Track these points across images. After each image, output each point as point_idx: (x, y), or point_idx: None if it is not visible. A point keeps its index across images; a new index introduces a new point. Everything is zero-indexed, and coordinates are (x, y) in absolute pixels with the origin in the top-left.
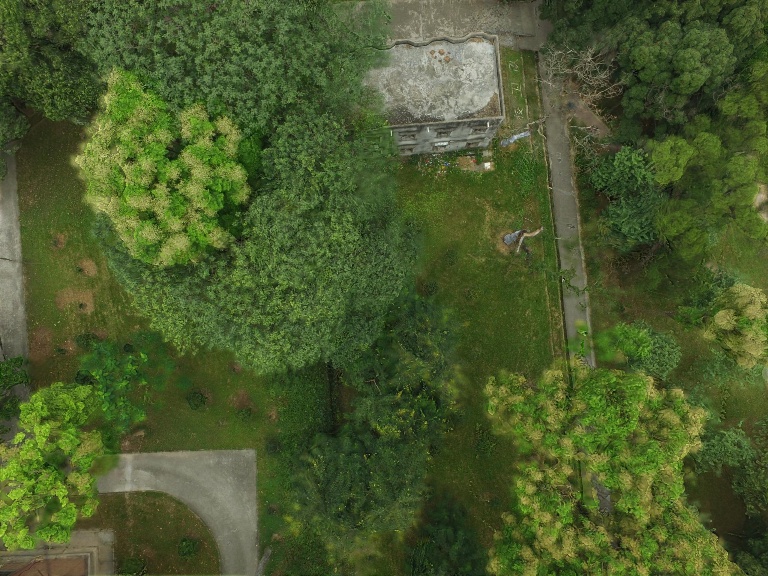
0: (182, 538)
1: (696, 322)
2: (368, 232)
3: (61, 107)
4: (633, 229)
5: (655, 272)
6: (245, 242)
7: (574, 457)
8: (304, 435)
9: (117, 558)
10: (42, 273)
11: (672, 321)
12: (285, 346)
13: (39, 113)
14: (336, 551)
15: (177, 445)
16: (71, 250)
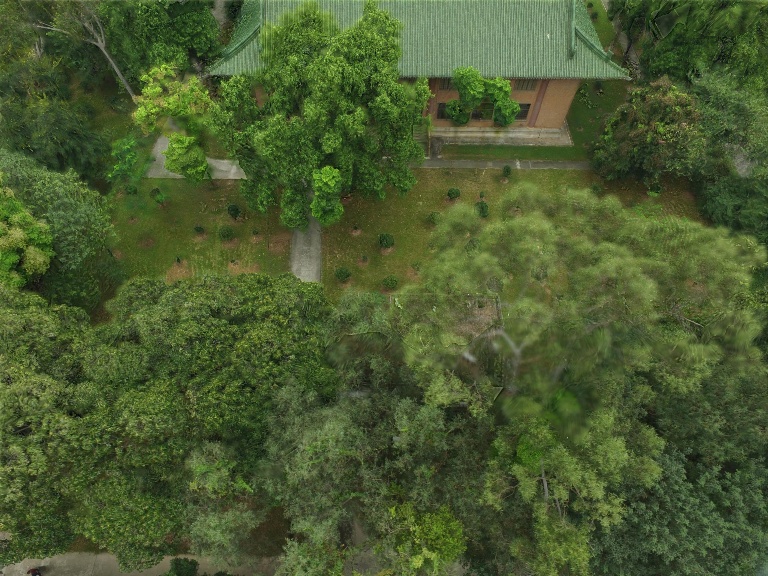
0: None
1: None
2: None
3: None
4: None
5: None
6: None
7: None
8: None
9: None
10: None
11: None
12: None
13: None
14: None
15: None
16: None
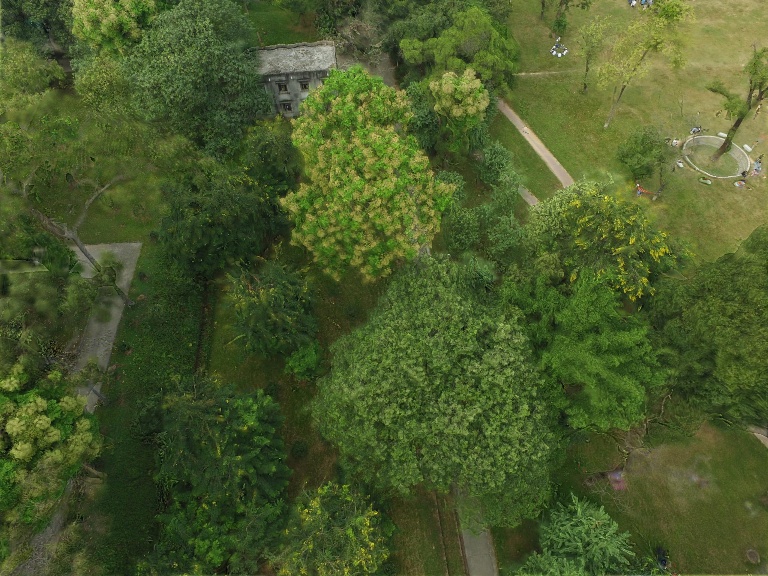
0: None
1: (453, 137)
2: (220, 40)
3: None
4: (421, 117)
5: (438, 137)
6: (149, 30)
7: (327, 117)
8: None
9: (4, 318)
10: None
11: (480, 200)
12: (161, 79)
13: (61, 51)
14: (194, 331)
15: (83, 240)
16: None
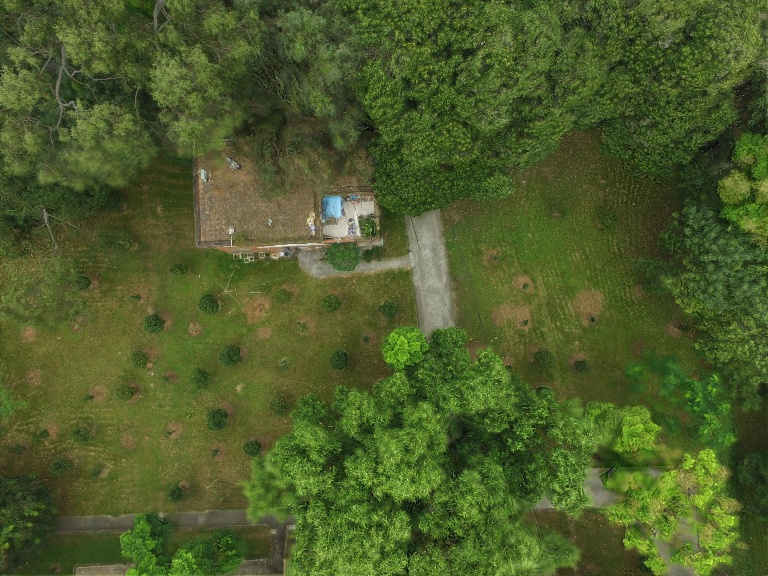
0: (639, 555)
1: None
2: None
3: (677, 130)
4: None
5: None
6: None
7: None
8: (727, 451)
9: (559, 574)
10: (474, 289)
11: None
12: None
13: None
14: None
15: None
16: (505, 266)
